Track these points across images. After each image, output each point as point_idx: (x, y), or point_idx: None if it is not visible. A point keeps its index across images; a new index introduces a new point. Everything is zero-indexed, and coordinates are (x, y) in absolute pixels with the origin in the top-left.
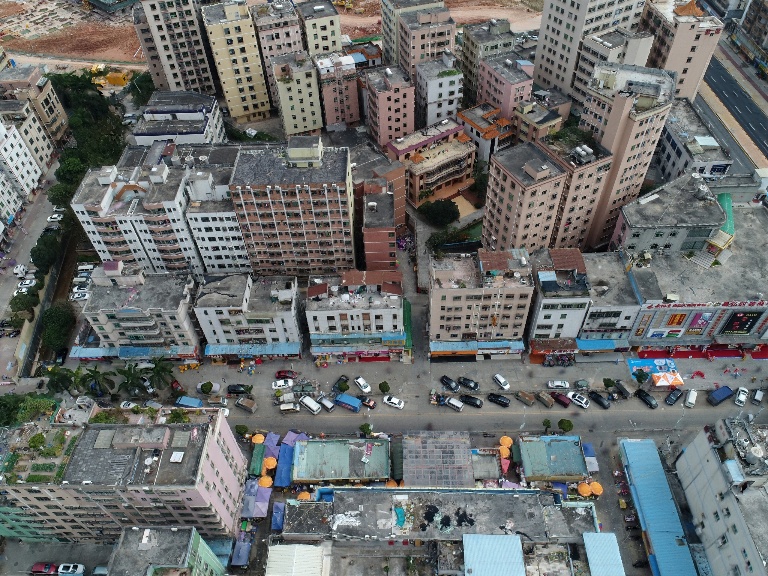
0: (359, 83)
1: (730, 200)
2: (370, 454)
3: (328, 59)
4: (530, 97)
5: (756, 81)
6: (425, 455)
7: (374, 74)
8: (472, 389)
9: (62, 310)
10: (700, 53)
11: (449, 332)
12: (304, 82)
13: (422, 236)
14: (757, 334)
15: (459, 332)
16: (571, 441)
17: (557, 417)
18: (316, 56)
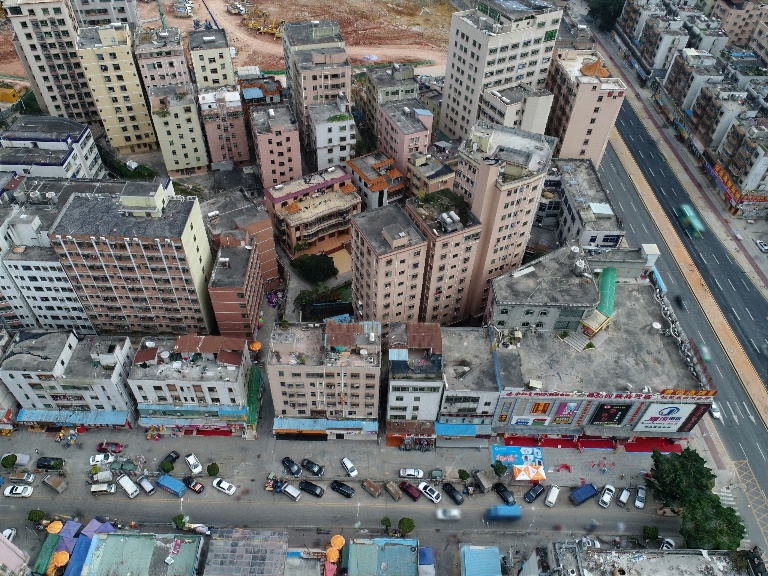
0: (249, 121)
1: (614, 276)
2: (177, 553)
3: (212, 94)
4: None
5: (674, 143)
6: (232, 561)
7: (260, 113)
8: (315, 474)
9: None
10: (604, 115)
11: (295, 408)
12: (183, 117)
13: (293, 292)
14: (629, 426)
15: (306, 409)
16: (408, 546)
17: (403, 512)
18: (203, 89)
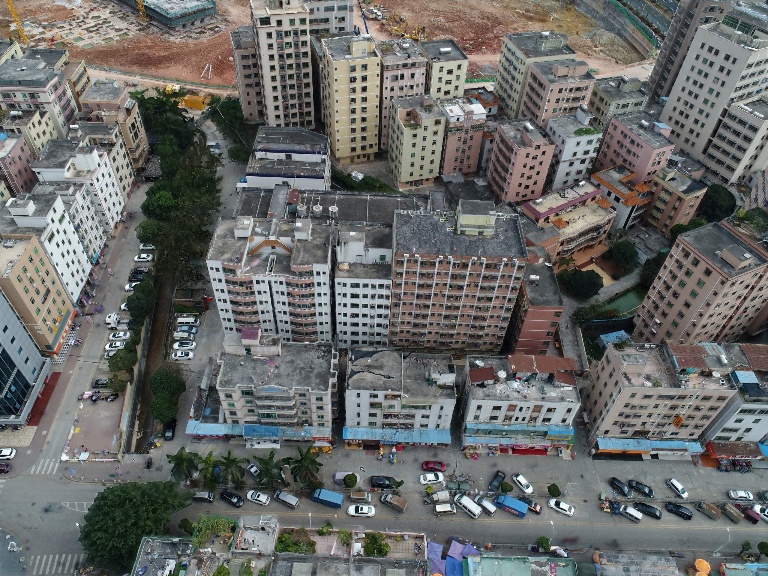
0: None
1: None
2: None
3: (457, 106)
4: (665, 162)
5: None
6: None
7: (506, 126)
8: (647, 496)
9: (173, 375)
10: None
11: (621, 429)
12: (431, 129)
13: None
14: None
15: (631, 429)
16: None
17: (747, 535)
18: (439, 101)
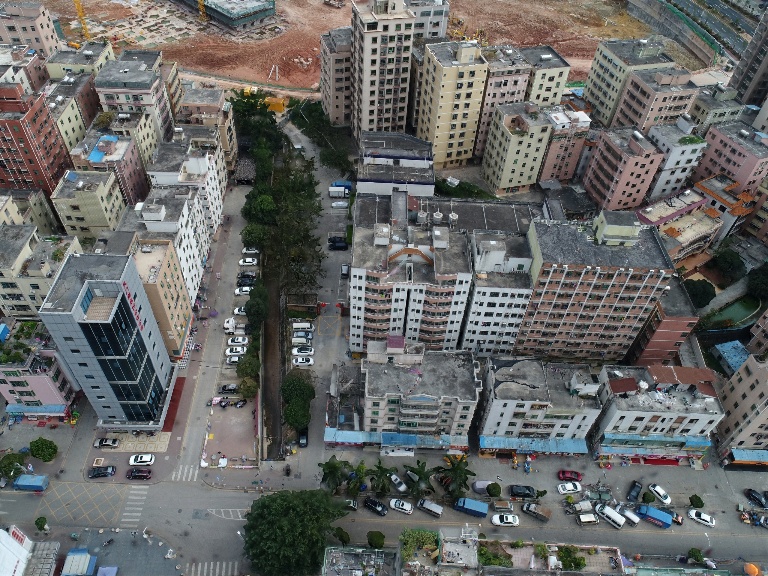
0: None
1: None
2: None
3: (561, 113)
4: None
5: None
6: None
7: (611, 134)
8: None
9: (305, 381)
10: None
11: (757, 440)
12: (537, 136)
13: None
14: None
15: (767, 440)
16: None
17: None
18: (539, 107)
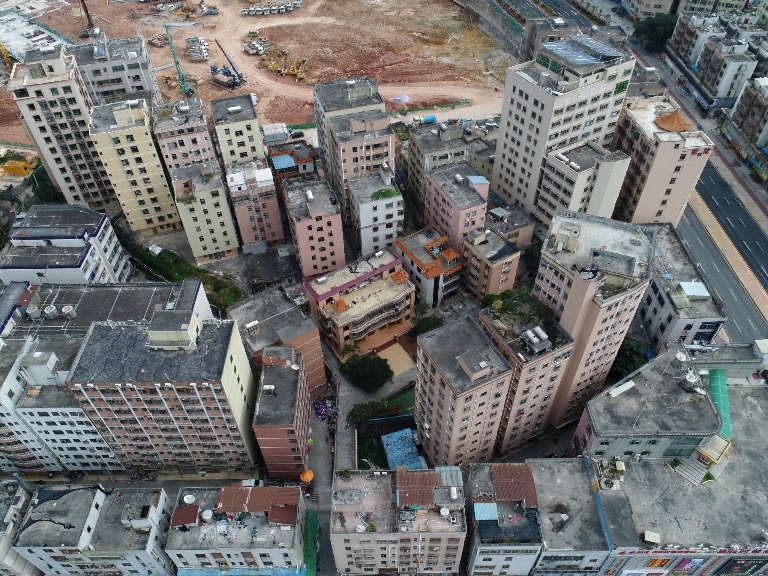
0: (282, 197)
1: (724, 379)
2: None
3: (241, 173)
4: (484, 220)
5: (750, 185)
6: None
7: (295, 193)
8: None
9: None
10: (686, 173)
11: (361, 568)
12: (210, 201)
13: (345, 403)
14: (762, 575)
15: (374, 567)
16: None
17: None
18: (230, 165)
